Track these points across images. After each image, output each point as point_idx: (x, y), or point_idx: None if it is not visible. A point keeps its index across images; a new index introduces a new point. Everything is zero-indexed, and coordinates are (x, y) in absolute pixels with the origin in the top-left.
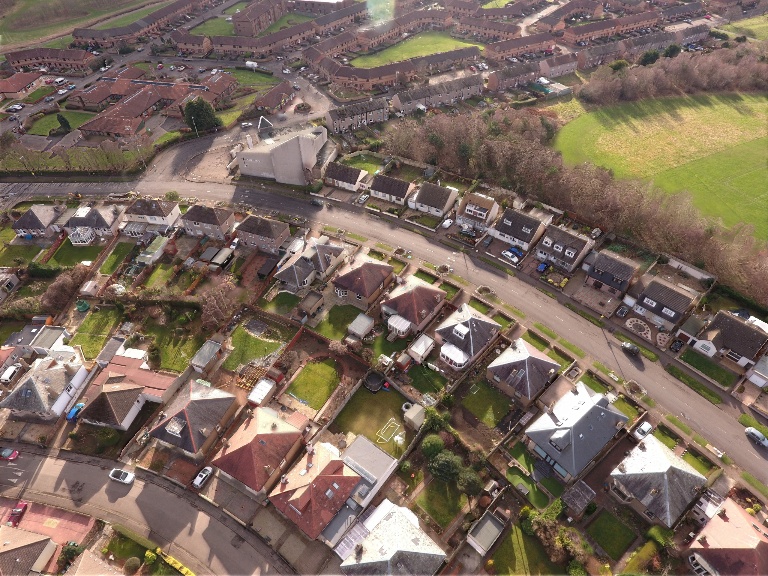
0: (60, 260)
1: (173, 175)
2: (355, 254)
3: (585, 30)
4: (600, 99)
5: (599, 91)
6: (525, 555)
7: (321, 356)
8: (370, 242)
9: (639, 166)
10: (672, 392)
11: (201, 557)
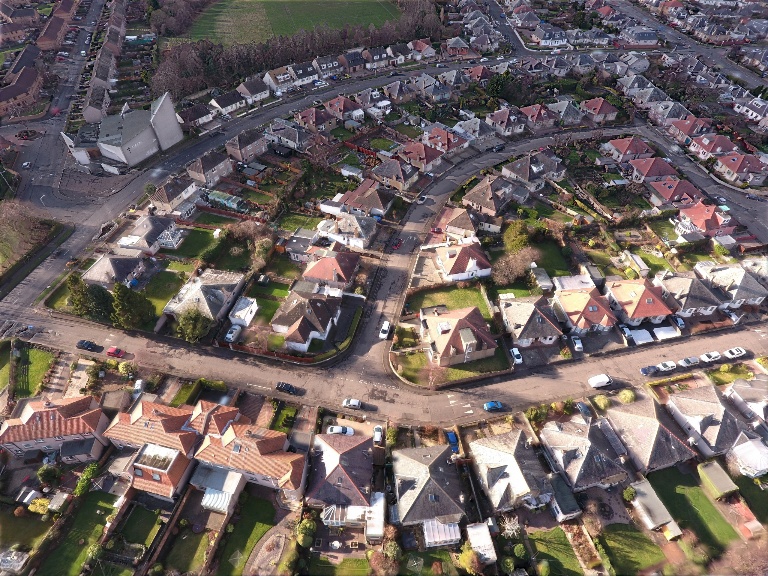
0: (194, 255)
1: (91, 204)
2: None
3: (67, 8)
4: (181, 30)
5: (178, 24)
6: (475, 112)
7: None
8: None
9: (265, 41)
10: (417, 73)
11: (466, 177)
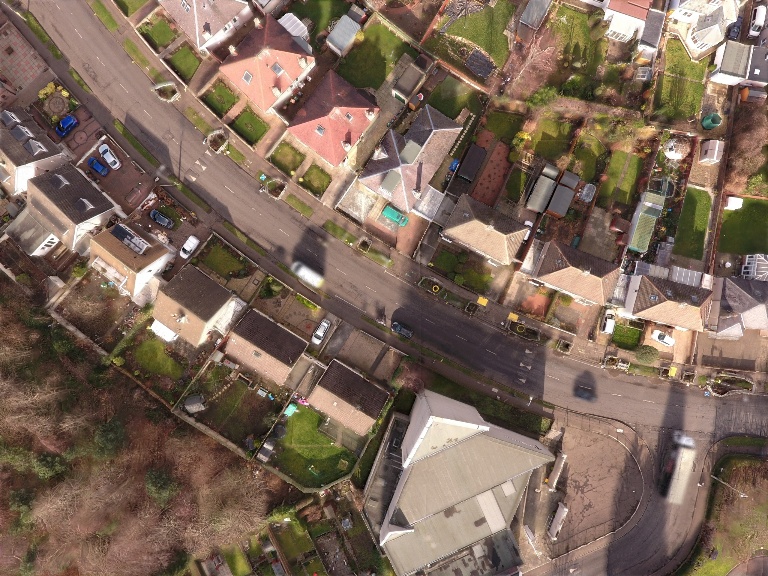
0: None
1: (660, 448)
2: (344, 191)
3: None
4: None
5: None
6: None
7: (397, 7)
8: (320, 219)
9: None
10: None
11: None
